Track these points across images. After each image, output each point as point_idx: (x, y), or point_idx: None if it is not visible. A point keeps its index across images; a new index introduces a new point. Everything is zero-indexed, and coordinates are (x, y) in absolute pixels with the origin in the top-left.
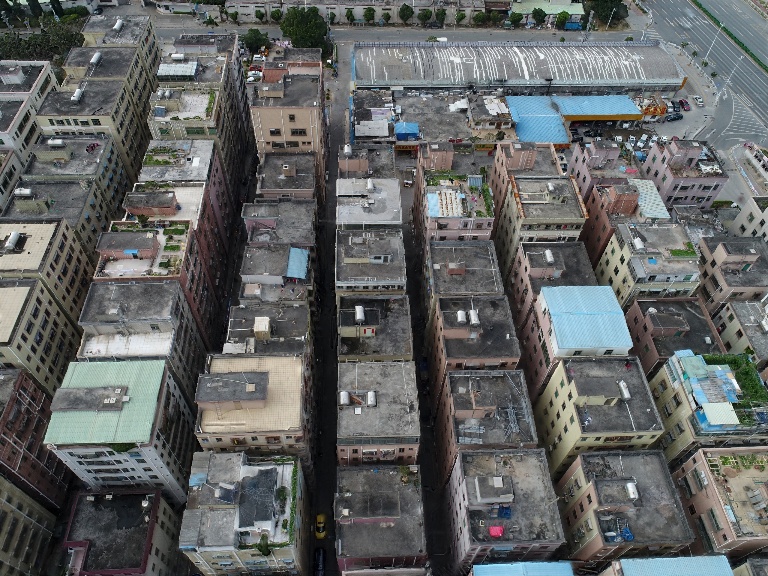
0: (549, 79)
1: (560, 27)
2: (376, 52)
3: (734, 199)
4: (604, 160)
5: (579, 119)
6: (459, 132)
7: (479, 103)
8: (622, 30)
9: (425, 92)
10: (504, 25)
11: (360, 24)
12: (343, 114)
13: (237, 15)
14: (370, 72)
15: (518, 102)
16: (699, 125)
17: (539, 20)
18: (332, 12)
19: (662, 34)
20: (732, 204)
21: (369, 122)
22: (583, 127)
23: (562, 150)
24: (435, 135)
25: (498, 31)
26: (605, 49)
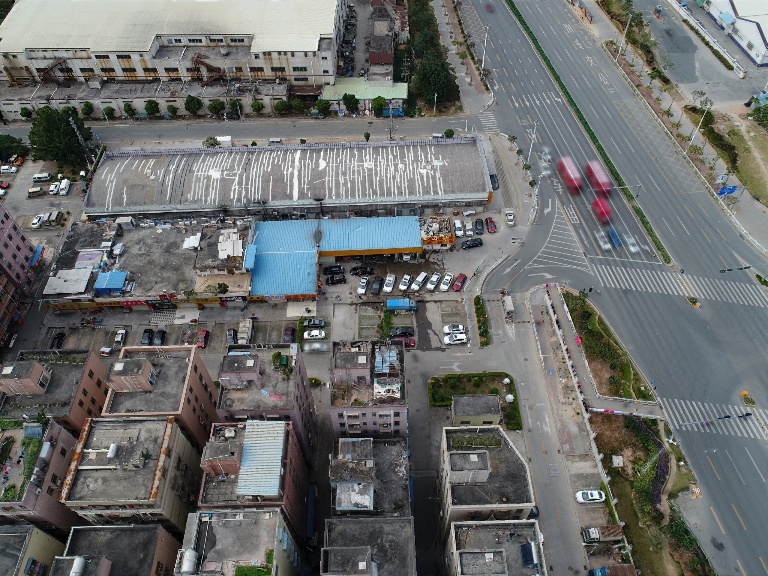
0: (319, 199)
1: (379, 113)
2: (125, 165)
3: (513, 369)
4: (240, 381)
5: (342, 254)
6: (181, 280)
7: (212, 241)
8: (453, 115)
9: (162, 221)
10: (311, 114)
11: (144, 118)
12: (47, 258)
13: (2, 113)
14: (106, 195)
15: (275, 231)
16: (501, 254)
17: (350, 108)
18: (109, 106)
19: (499, 119)
20: (504, 379)
21: (68, 272)
22: (354, 261)
23: (312, 298)
24: (149, 286)
25: (304, 121)
26: (407, 151)
